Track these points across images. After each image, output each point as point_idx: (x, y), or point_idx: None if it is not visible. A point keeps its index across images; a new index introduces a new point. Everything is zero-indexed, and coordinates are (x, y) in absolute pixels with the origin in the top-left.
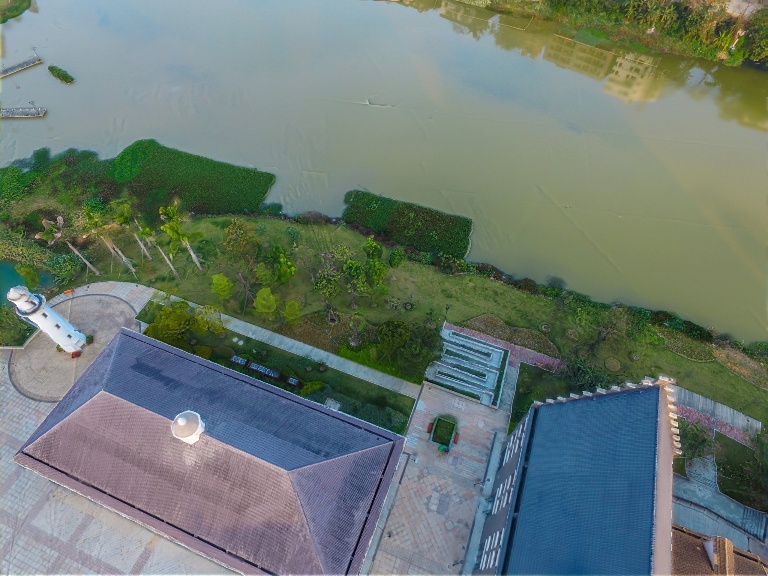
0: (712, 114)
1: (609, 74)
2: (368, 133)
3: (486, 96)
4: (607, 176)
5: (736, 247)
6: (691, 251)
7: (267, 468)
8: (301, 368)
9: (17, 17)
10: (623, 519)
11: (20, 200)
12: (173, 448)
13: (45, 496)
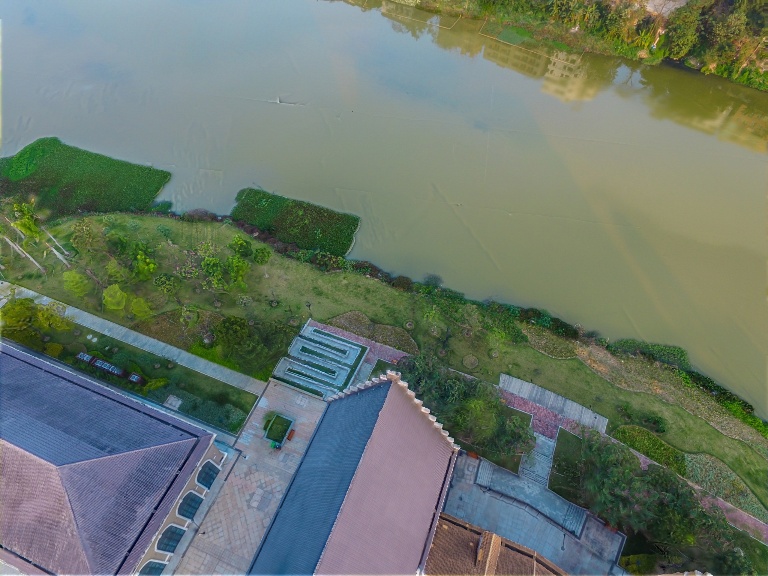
0: (622, 112)
1: (526, 73)
2: (273, 131)
3: (398, 94)
4: (505, 174)
5: (620, 245)
6: (574, 249)
7: (38, 464)
8: (149, 365)
9: None
10: (325, 513)
11: None
12: None
13: None
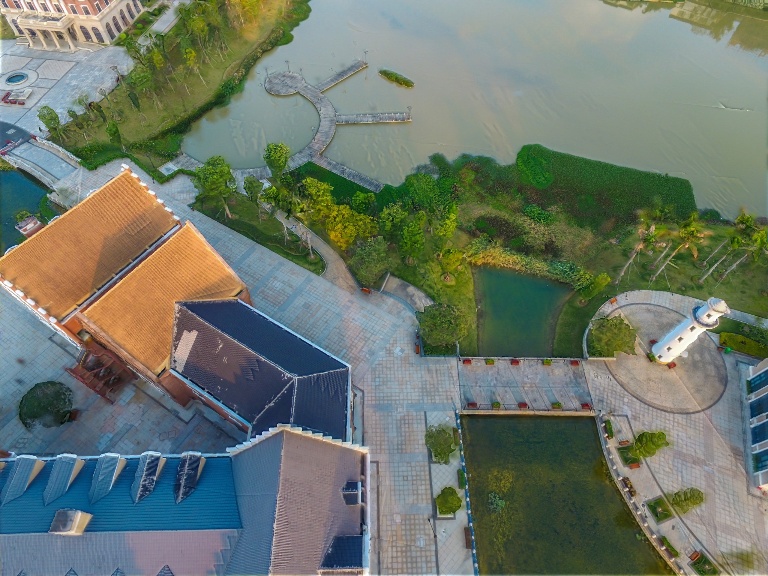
0: None
1: None
2: (747, 137)
3: None
4: None
5: None
6: None
7: None
8: None
9: (307, 20)
10: None
11: (457, 207)
12: None
13: (757, 510)
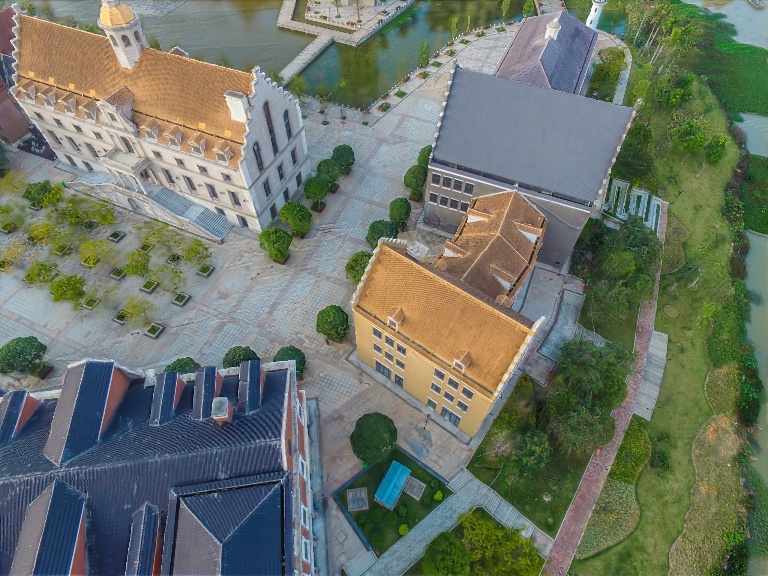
0: None
1: None
2: None
3: None
4: None
5: None
6: None
7: None
8: None
9: None
10: None
11: None
12: (541, 36)
13: None
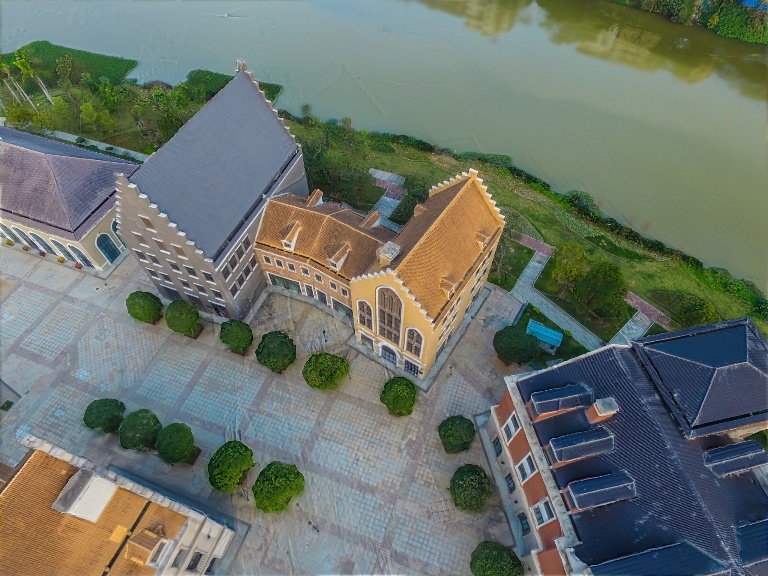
0: (503, 19)
1: None
2: (220, 35)
3: (324, 10)
4: (401, 60)
5: (479, 100)
6: (444, 102)
7: (34, 154)
8: None
9: None
10: None
11: None
12: None
13: None
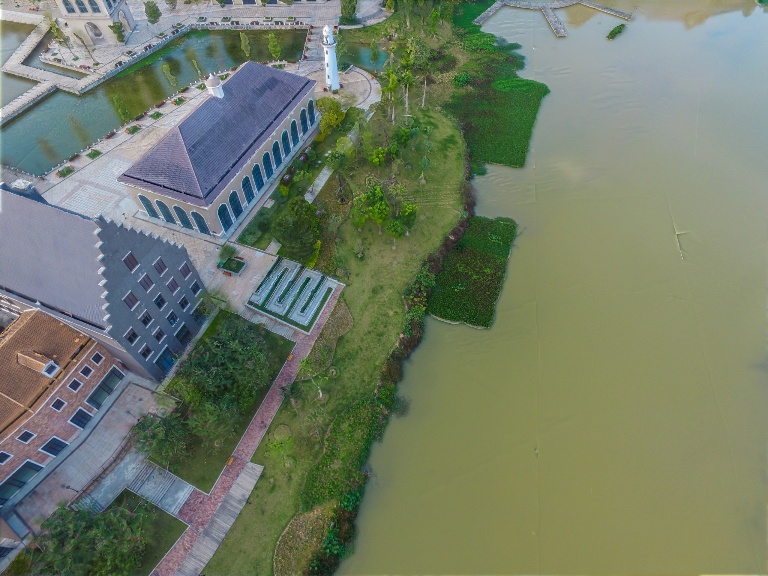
0: None
1: None
2: (618, 234)
3: None
4: (631, 542)
5: None
6: None
7: None
8: (301, 185)
9: None
10: None
11: (463, 49)
12: None
13: None
